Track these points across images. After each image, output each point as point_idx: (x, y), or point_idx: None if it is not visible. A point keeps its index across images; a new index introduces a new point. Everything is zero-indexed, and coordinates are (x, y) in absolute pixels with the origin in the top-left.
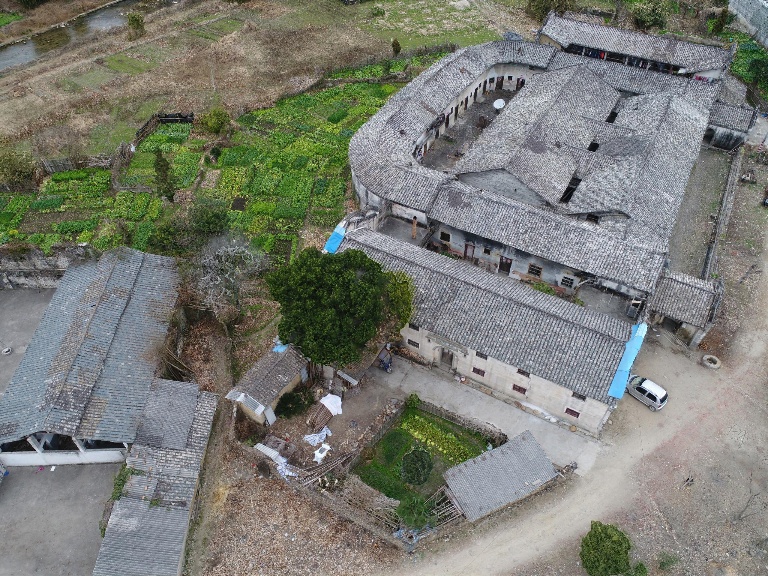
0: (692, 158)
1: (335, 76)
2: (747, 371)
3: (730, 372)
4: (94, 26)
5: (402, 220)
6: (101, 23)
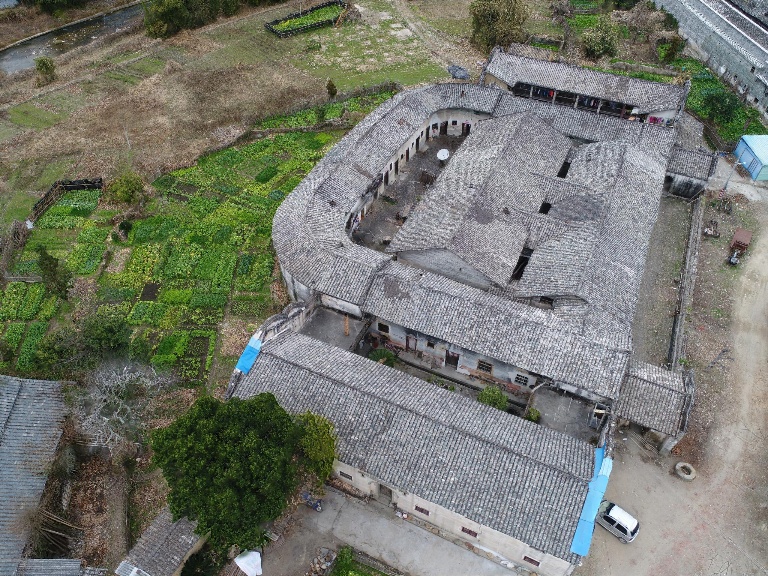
0: (651, 218)
1: (265, 124)
2: (725, 480)
3: (706, 483)
4: (2, 68)
5: (334, 311)
6: (10, 65)
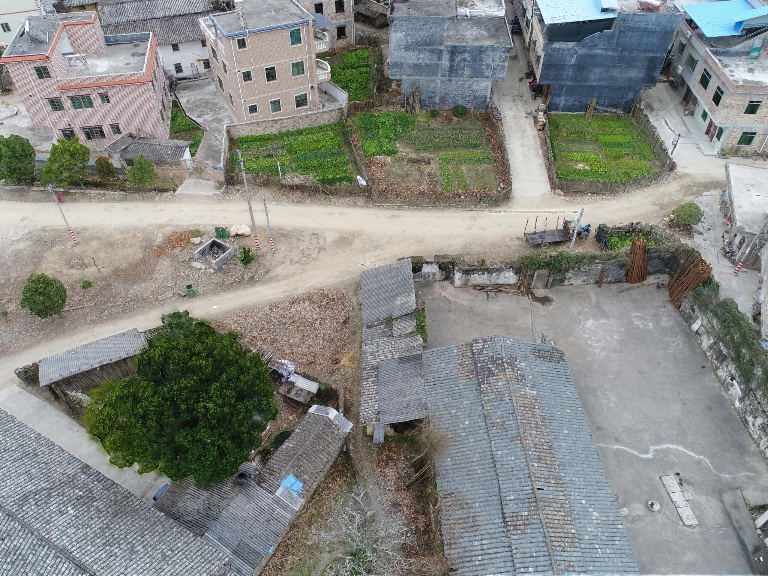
0: None
1: None
2: None
3: None
4: None
5: None
6: None
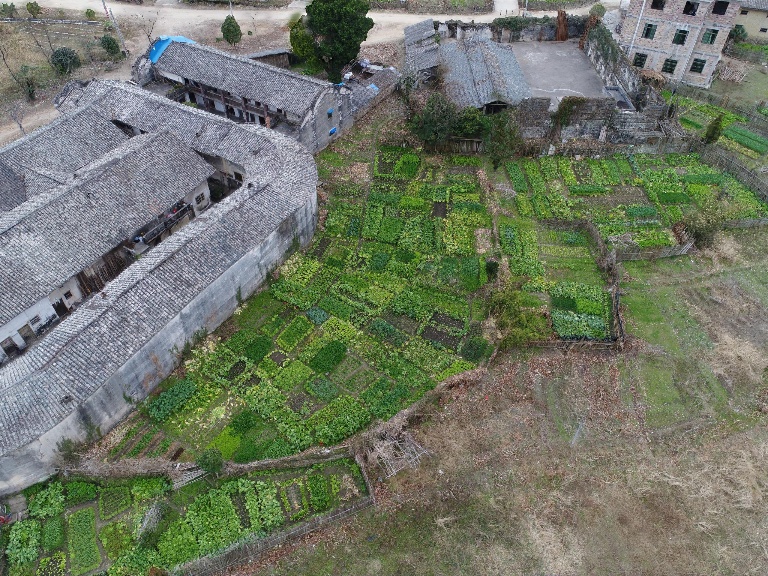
0: None
1: (329, 508)
2: None
3: None
4: None
5: None
6: None
